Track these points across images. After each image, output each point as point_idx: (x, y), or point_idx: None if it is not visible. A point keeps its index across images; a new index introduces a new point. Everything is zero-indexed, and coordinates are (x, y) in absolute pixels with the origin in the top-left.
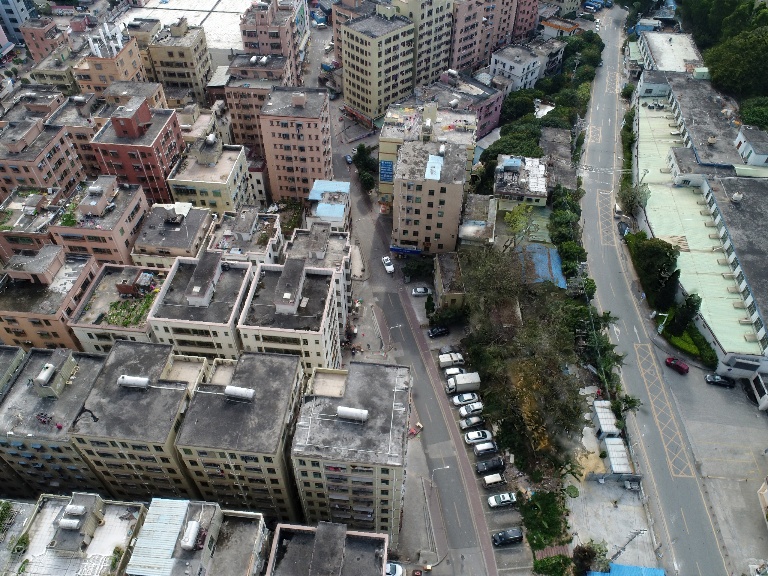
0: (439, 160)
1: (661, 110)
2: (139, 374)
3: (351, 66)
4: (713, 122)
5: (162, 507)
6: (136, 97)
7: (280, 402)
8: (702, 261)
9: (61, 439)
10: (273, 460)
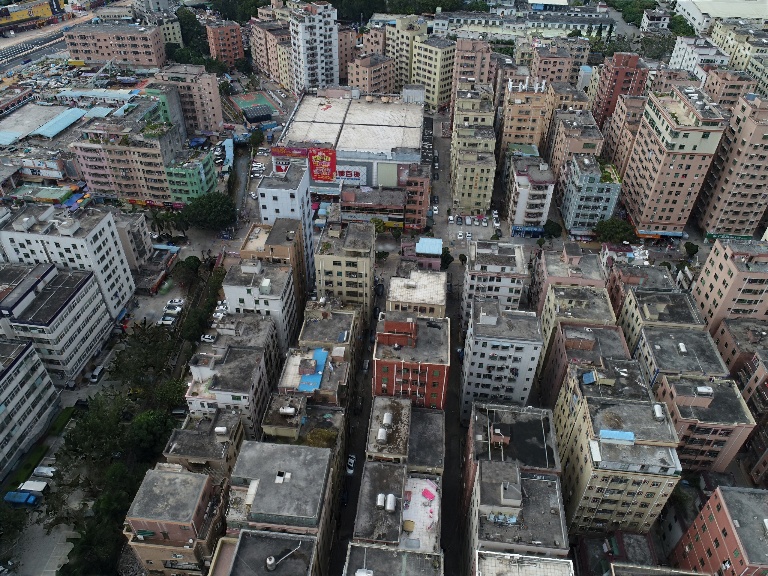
0: (571, 39)
1: (462, 26)
2: None
3: (445, 73)
4: (482, 15)
5: None
6: (616, 53)
7: None
8: None
9: None
10: None
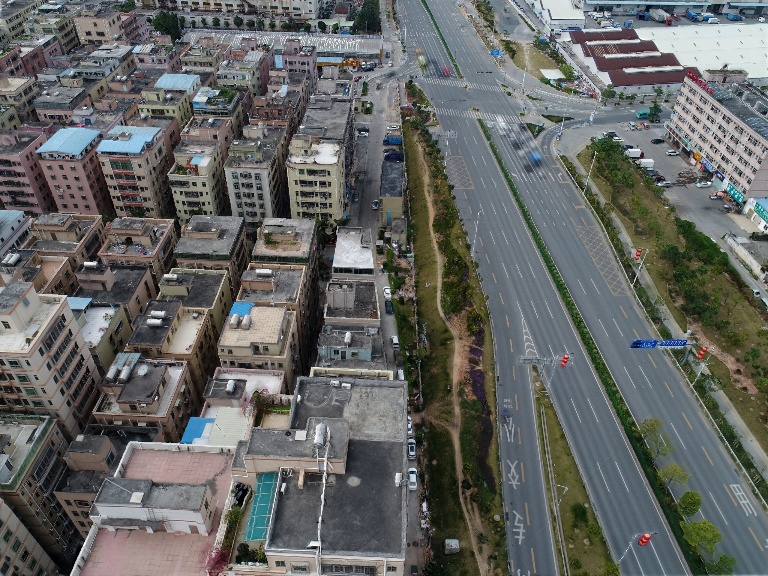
0: None
1: None
2: None
3: None
4: None
5: (41, 7)
6: None
7: (19, 1)
8: None
9: (2, 30)
10: (37, 5)
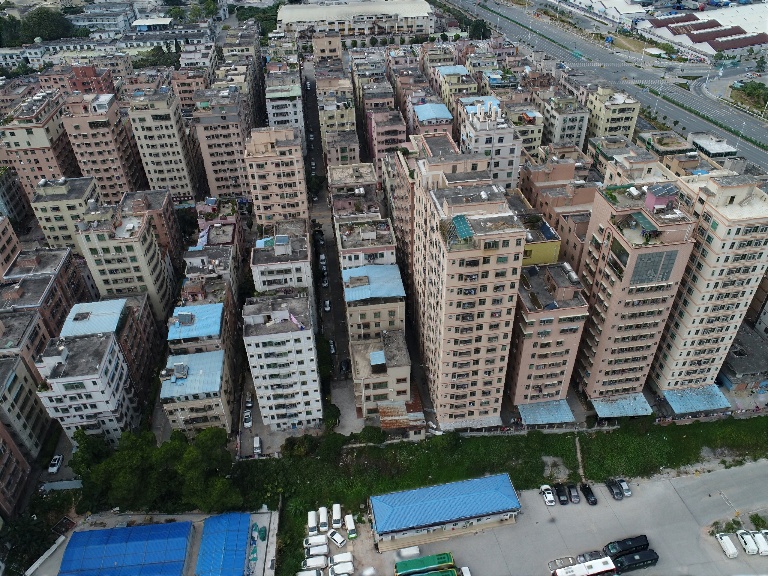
0: None
1: None
2: None
3: None
4: None
5: None
6: None
7: None
8: None
9: None
10: None
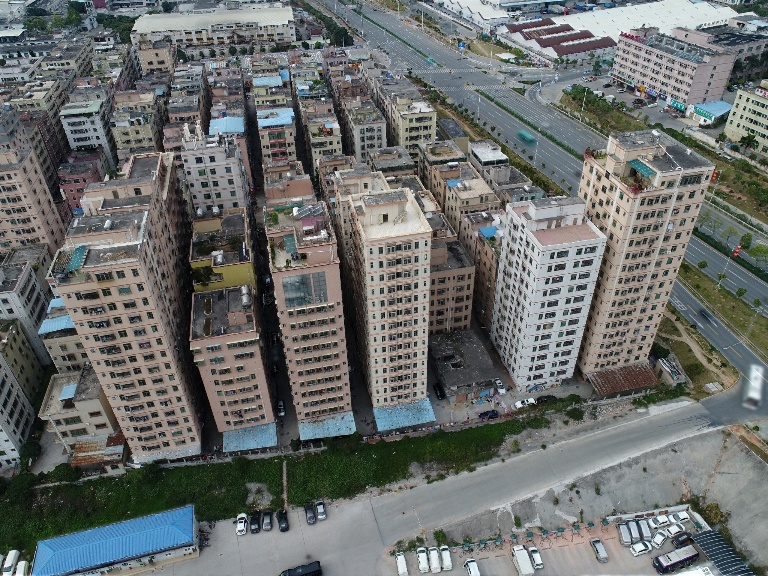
0: None
1: None
2: (55, 58)
3: None
4: None
5: None
6: None
7: None
8: (6, 62)
9: (74, 69)
10: None
